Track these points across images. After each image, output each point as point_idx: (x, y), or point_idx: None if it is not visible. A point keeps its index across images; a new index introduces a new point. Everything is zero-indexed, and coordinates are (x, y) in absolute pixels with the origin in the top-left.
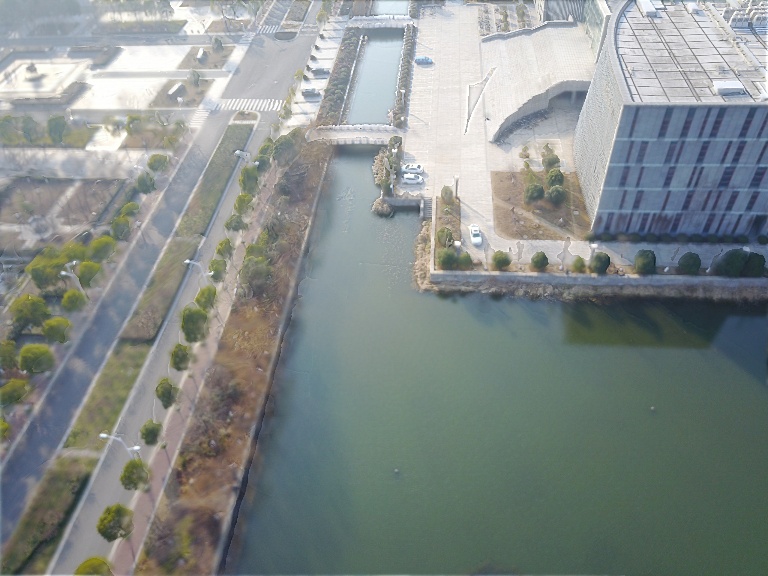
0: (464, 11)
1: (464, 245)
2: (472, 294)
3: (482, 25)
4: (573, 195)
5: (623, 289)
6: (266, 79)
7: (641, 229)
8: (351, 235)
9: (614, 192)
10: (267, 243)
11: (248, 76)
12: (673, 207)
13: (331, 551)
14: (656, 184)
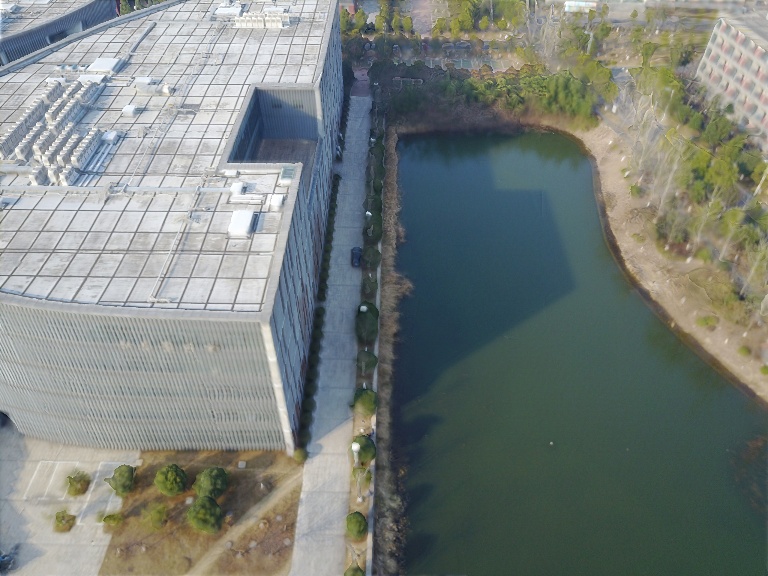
0: None
1: None
2: None
3: None
4: (199, 462)
5: (383, 437)
6: None
7: None
8: None
9: (289, 398)
10: None
11: None
12: (301, 349)
13: None
14: (294, 350)
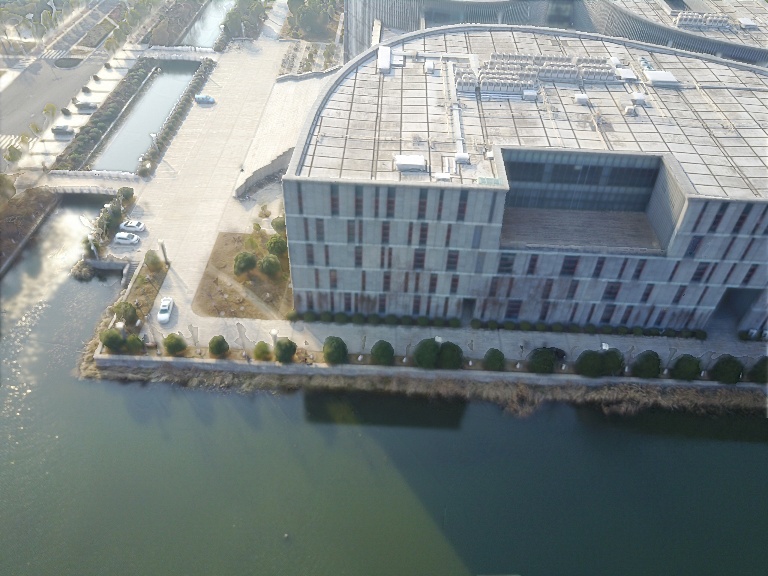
0: (274, 47)
1: (149, 322)
2: (138, 383)
3: (284, 64)
4: None
5: (311, 379)
6: (22, 111)
7: (347, 309)
8: (45, 302)
9: (304, 270)
10: None
11: (3, 107)
12: (373, 287)
13: None
14: (347, 263)
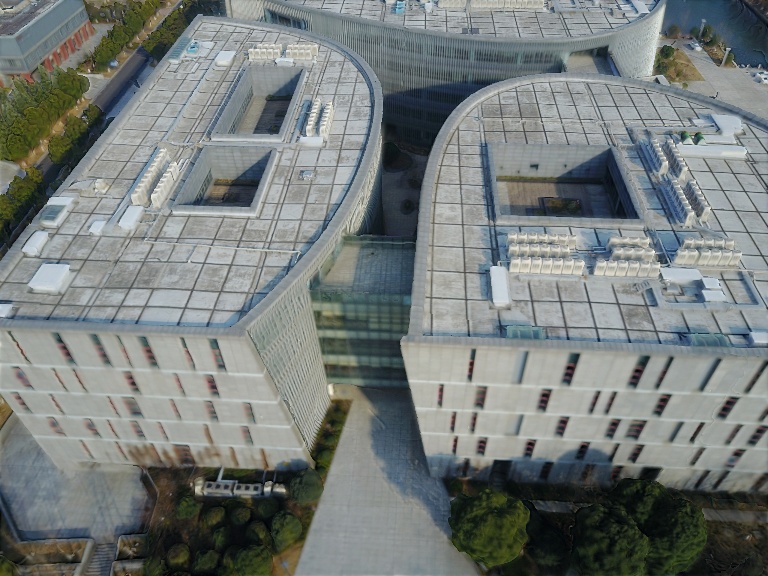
0: None
1: None
2: None
3: None
4: None
5: None
6: None
7: None
8: None
9: None
10: None
11: None
12: None
13: (694, 8)
14: None
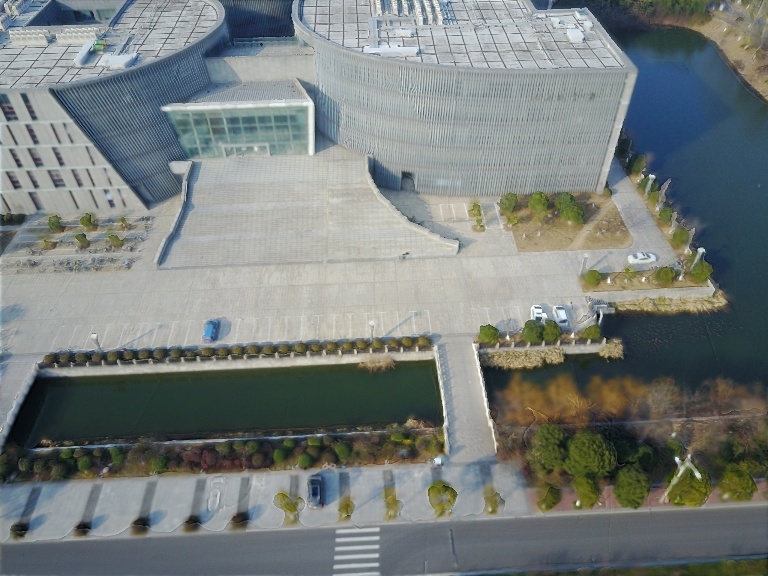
0: (8, 292)
1: None
2: None
3: (93, 266)
4: None
5: None
6: None
7: None
8: None
9: None
10: (759, 457)
11: None
12: None
13: None
14: None
